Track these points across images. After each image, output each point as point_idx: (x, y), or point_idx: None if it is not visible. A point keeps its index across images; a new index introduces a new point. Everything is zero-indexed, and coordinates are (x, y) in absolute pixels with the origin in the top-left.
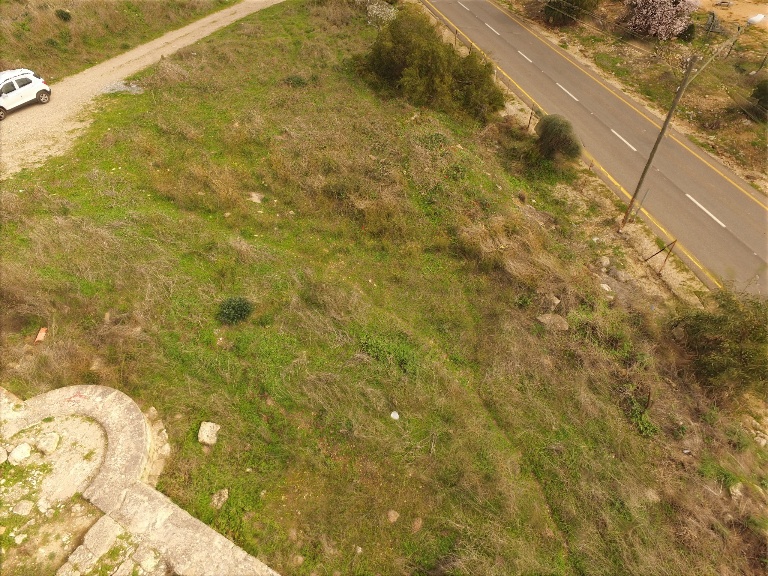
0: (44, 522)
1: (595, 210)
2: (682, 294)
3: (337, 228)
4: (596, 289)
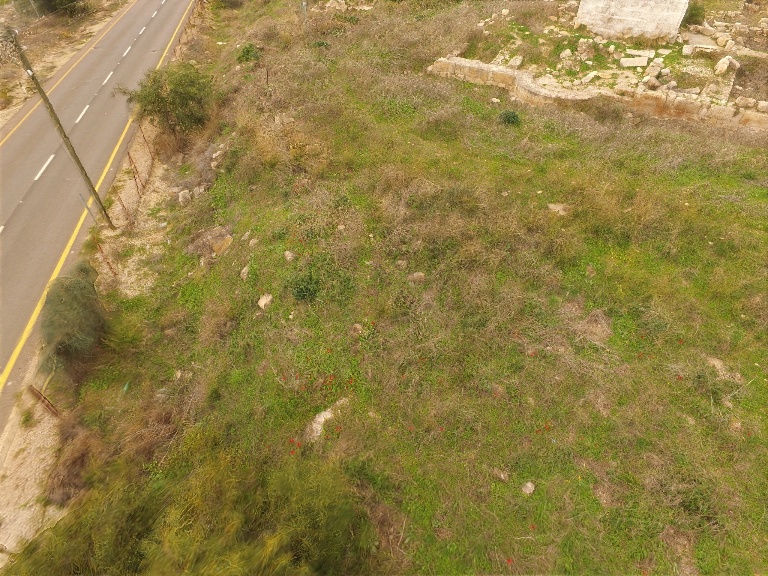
0: (543, 72)
1: (127, 251)
2: (145, 173)
3: (449, 168)
4: (242, 121)
